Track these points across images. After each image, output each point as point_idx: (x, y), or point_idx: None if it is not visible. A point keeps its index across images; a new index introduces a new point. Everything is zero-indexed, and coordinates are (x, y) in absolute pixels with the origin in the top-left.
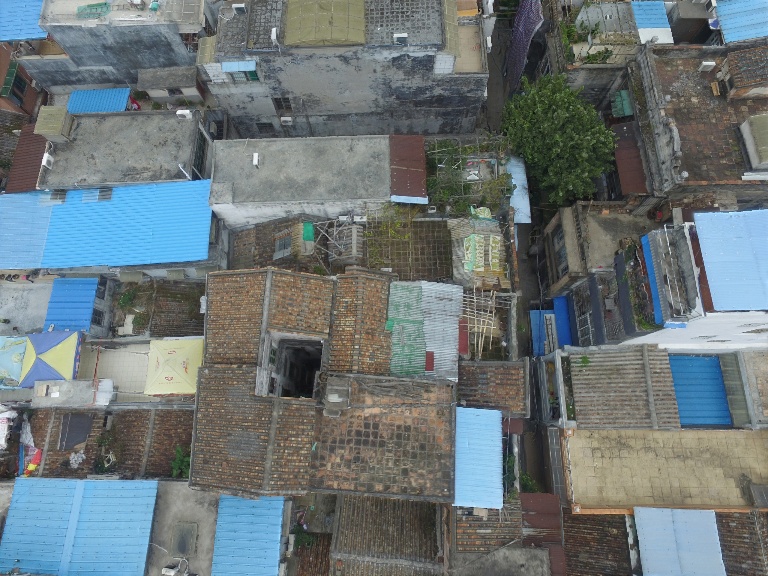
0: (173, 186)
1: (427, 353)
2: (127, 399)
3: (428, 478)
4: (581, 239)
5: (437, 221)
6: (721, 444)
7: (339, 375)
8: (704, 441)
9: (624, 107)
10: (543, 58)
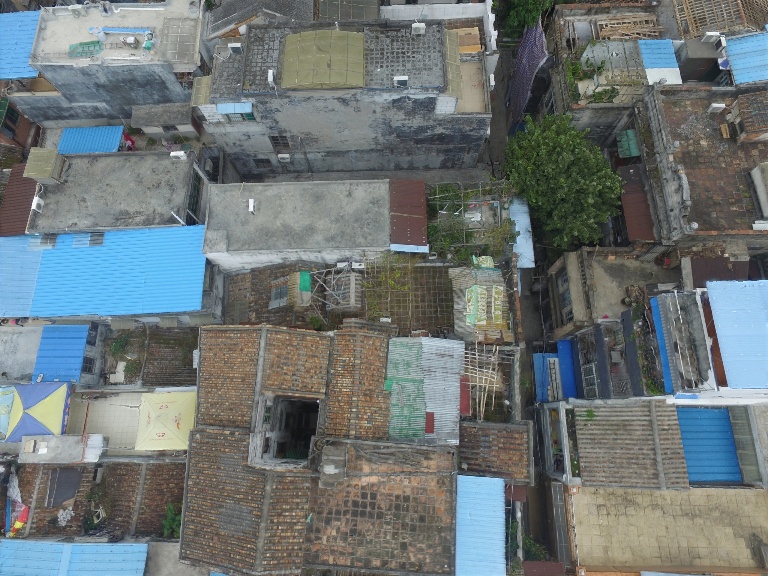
0: (166, 231)
1: (427, 414)
2: (118, 451)
3: (428, 553)
4: (586, 287)
5: (438, 266)
6: (731, 501)
7: (335, 441)
8: (713, 498)
9: (630, 147)
10: (547, 92)
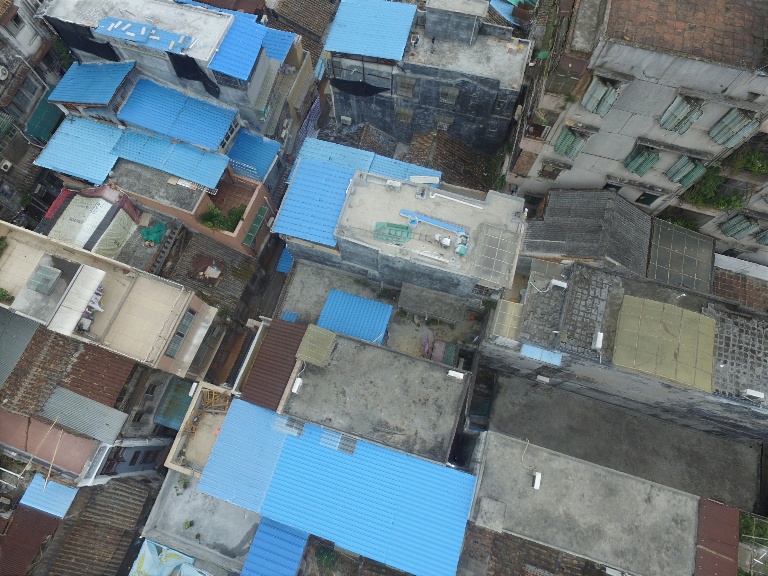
0: (427, 466)
1: None
2: None
3: None
4: None
5: None
6: None
7: None
8: None
9: None
10: None
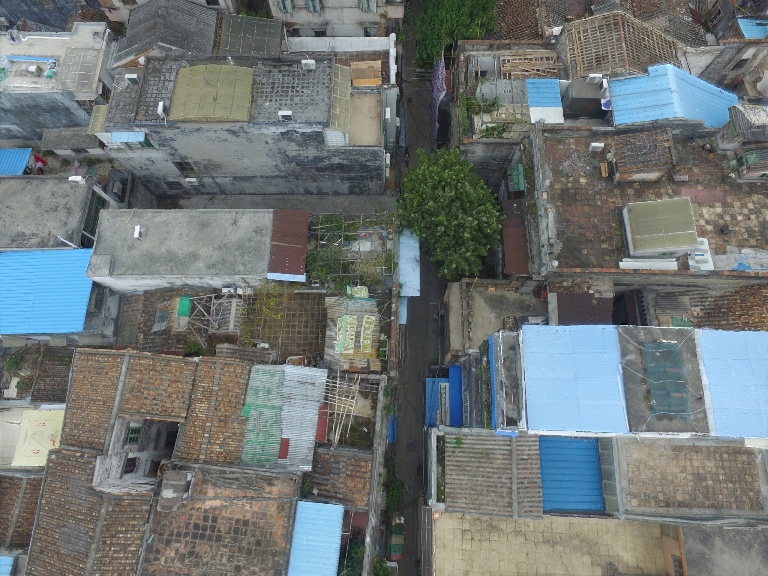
0: (58, 254)
1: (282, 440)
2: (4, 465)
3: (260, 575)
4: (462, 317)
5: (324, 293)
6: (591, 530)
7: (184, 465)
8: (575, 526)
9: (519, 181)
10: None
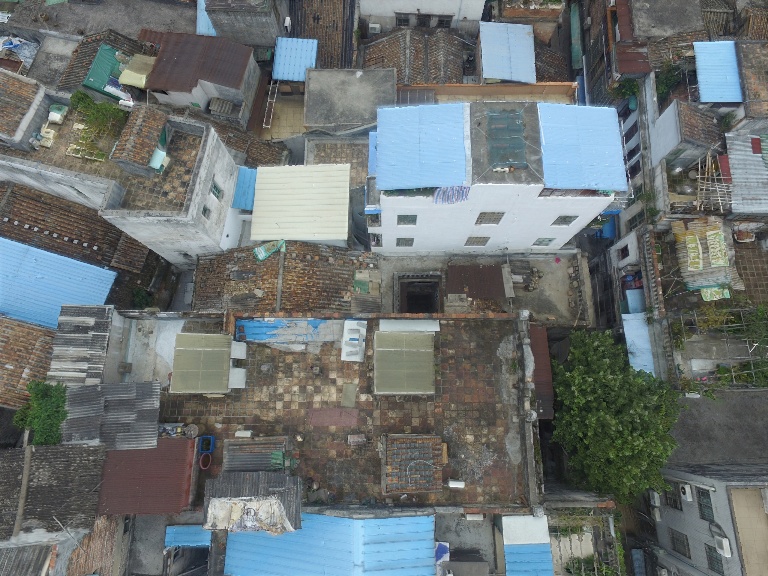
0: None
1: (760, 152)
2: None
3: (759, 54)
4: None
5: None
6: None
7: None
8: None
9: None
10: None
